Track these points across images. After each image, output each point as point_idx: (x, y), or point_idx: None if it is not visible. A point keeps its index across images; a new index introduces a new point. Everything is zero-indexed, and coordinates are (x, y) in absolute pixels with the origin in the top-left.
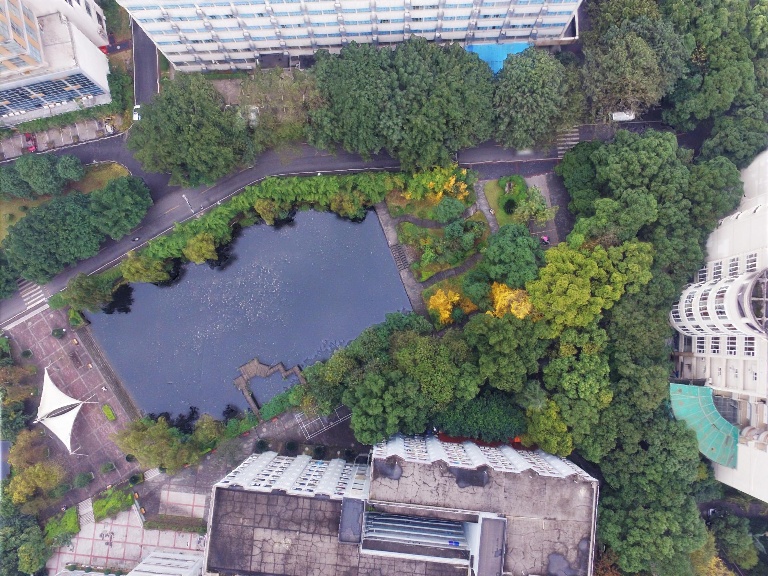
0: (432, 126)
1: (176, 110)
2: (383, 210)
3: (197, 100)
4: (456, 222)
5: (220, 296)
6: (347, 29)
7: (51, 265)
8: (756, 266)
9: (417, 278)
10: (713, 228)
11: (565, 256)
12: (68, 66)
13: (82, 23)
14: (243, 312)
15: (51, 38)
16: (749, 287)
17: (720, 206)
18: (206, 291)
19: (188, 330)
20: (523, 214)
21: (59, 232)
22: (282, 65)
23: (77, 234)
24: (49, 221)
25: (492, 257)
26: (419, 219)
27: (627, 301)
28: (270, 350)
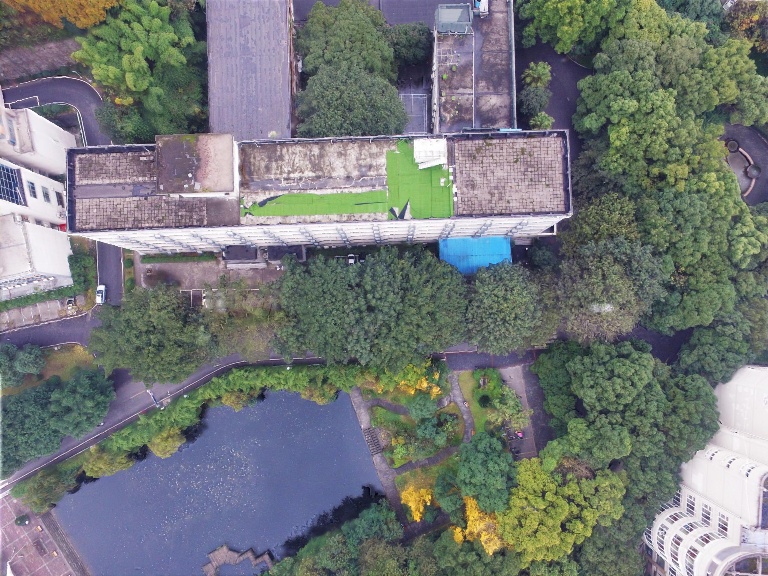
0: (401, 349)
1: (135, 333)
2: (356, 392)
3: (157, 321)
4: (428, 424)
5: (188, 480)
6: (315, 237)
7: (11, 465)
8: (727, 531)
9: (390, 464)
10: (687, 461)
11: (536, 487)
12: (23, 270)
13: (39, 215)
14: (212, 497)
15: (5, 240)
16: (718, 572)
17: (695, 444)
18: (174, 475)
19: (156, 515)
20: (496, 419)
21: (18, 437)
22: (249, 257)
23: (37, 437)
24: (7, 425)
25: (463, 478)
26: (392, 404)
27: (598, 535)
28: (240, 536)
